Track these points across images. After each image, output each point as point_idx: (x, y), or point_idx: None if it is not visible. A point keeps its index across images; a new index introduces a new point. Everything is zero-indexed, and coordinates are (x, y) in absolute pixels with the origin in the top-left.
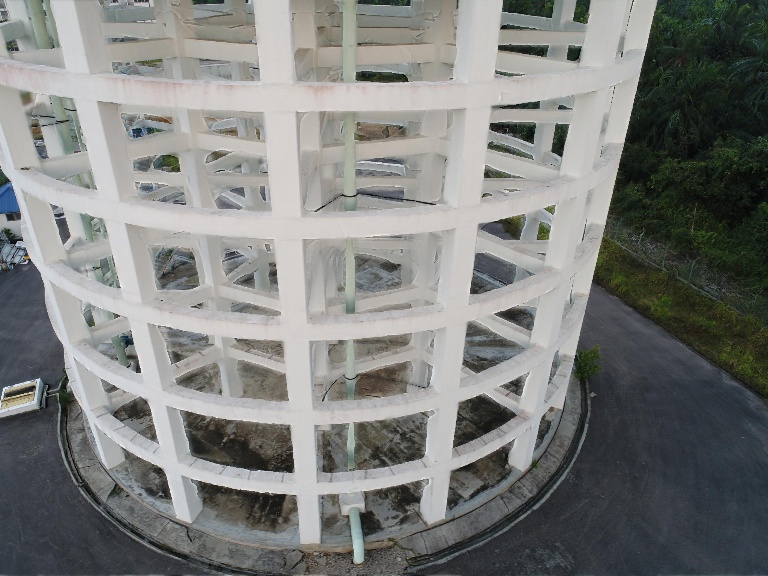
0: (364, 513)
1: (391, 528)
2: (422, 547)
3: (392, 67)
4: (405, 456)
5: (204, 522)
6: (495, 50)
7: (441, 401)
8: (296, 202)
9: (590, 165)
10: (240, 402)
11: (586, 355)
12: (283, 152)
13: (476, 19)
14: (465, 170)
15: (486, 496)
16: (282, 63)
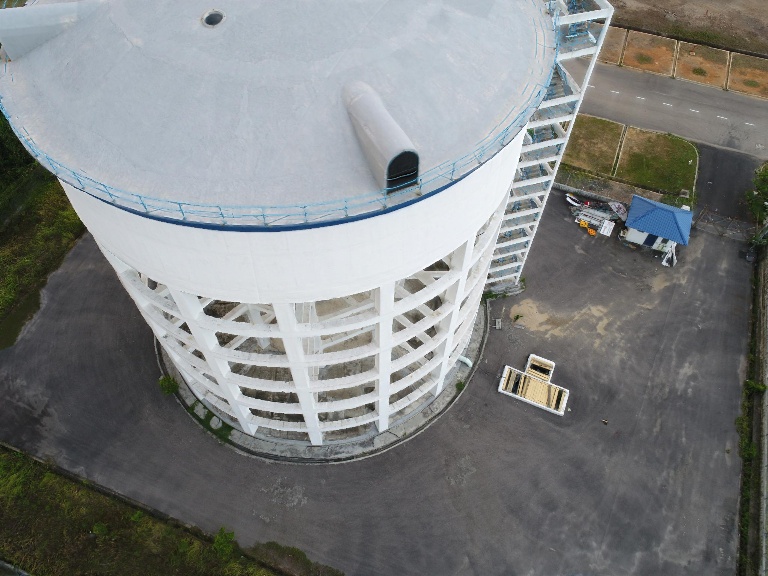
0: None
1: None
2: None
3: None
4: None
5: None
6: None
7: None
8: None
9: None
10: None
11: None
12: None
13: None
14: None
15: None
16: None
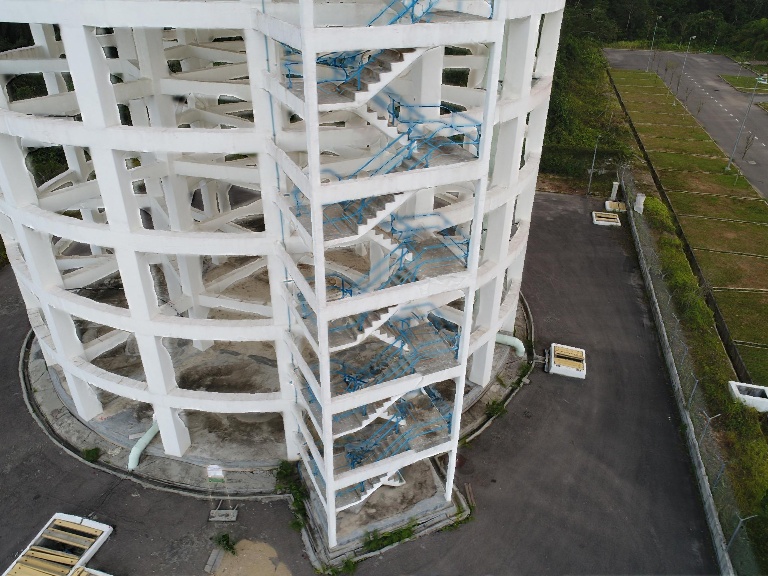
0: None
1: None
2: None
3: None
4: None
5: None
6: None
7: None
8: None
9: None
10: None
11: None
12: None
13: None
14: None
15: None
16: None
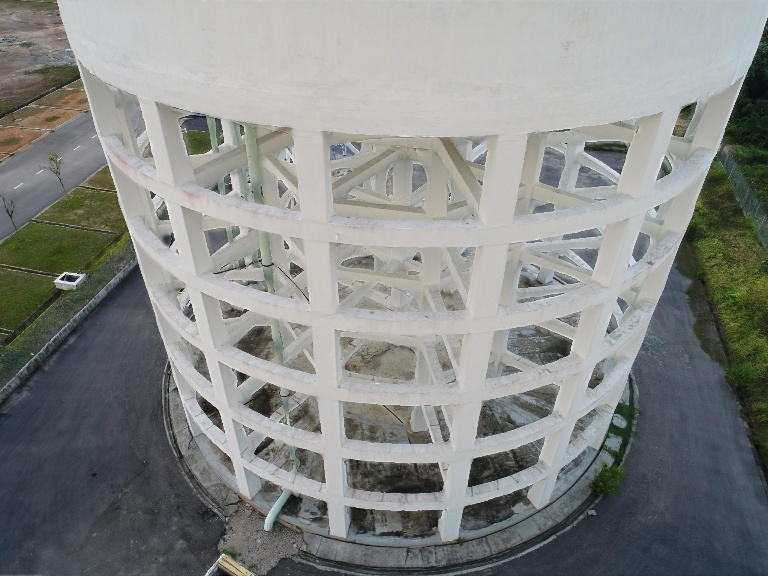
0: (296, 497)
1: (303, 520)
2: (315, 548)
3: (388, 147)
4: (364, 471)
5: (201, 440)
6: (324, 199)
7: (324, 449)
8: (192, 265)
9: (491, 309)
10: (197, 377)
11: (605, 471)
12: (179, 229)
13: (300, 172)
14: (312, 285)
15: (393, 541)
16: (167, 171)
